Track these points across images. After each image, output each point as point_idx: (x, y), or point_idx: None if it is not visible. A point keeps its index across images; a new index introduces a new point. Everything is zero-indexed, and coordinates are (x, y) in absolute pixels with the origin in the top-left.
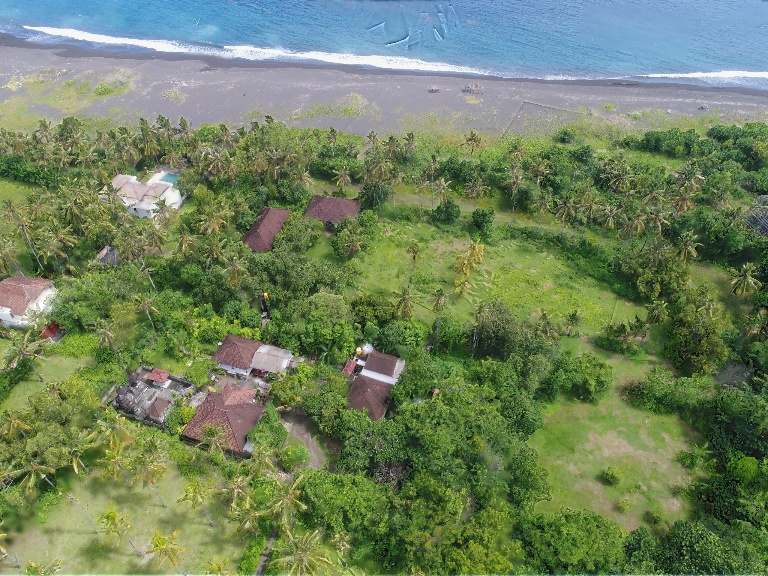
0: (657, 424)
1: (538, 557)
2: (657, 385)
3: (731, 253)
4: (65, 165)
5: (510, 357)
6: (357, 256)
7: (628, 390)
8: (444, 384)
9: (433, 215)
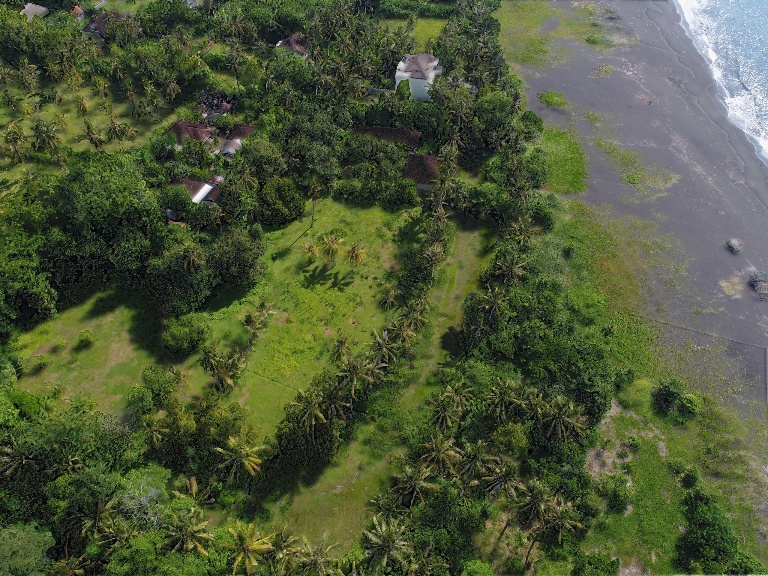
0: None
1: None
2: None
3: None
4: None
5: None
6: None
7: None
8: None
9: None
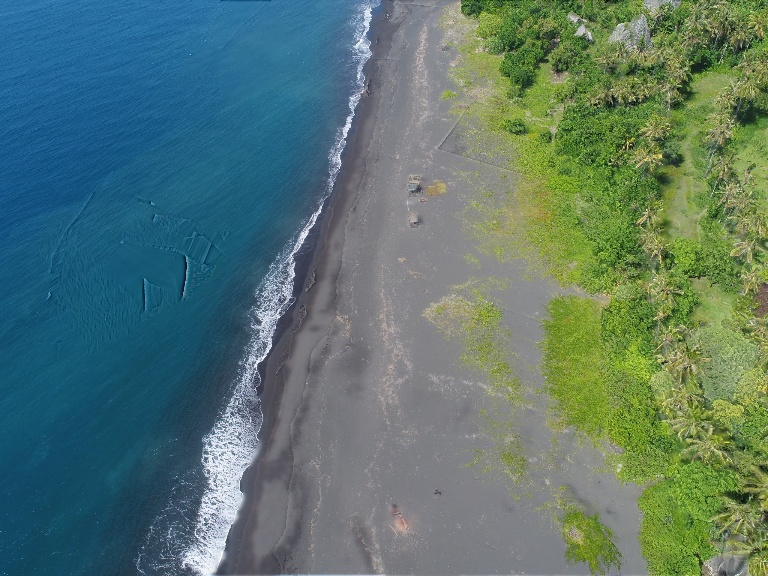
0: None
1: None
2: None
3: None
4: None
5: None
6: None
7: None
8: None
9: None
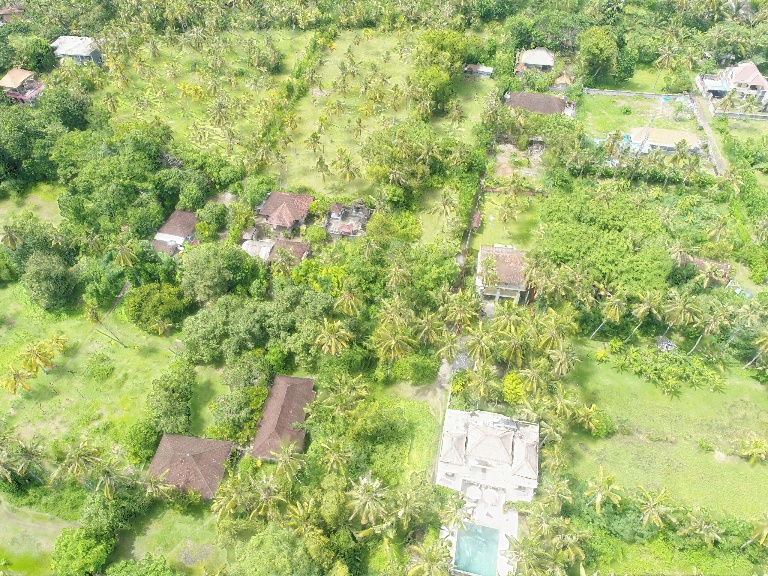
0: None
1: None
2: None
3: None
4: None
5: None
6: None
7: None
8: None
9: None
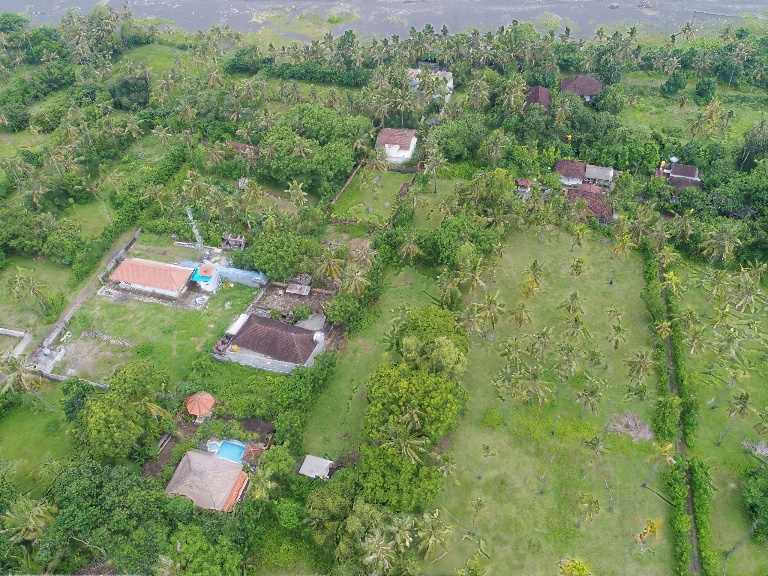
0: None
1: None
2: None
3: None
4: (360, 64)
5: None
6: None
7: None
8: (761, 162)
9: (663, 88)
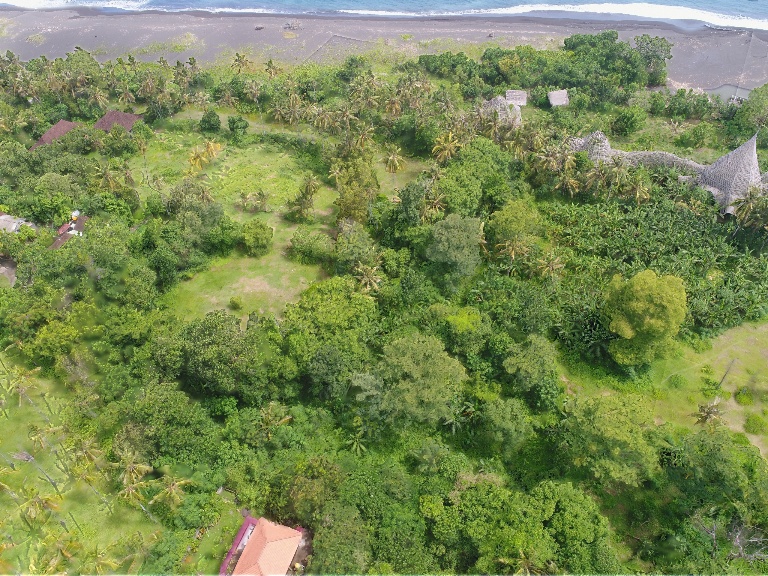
0: (300, 271)
1: (108, 334)
2: (294, 238)
3: (432, 149)
4: None
5: (176, 216)
6: (122, 156)
7: (289, 248)
8: None
9: (200, 125)
